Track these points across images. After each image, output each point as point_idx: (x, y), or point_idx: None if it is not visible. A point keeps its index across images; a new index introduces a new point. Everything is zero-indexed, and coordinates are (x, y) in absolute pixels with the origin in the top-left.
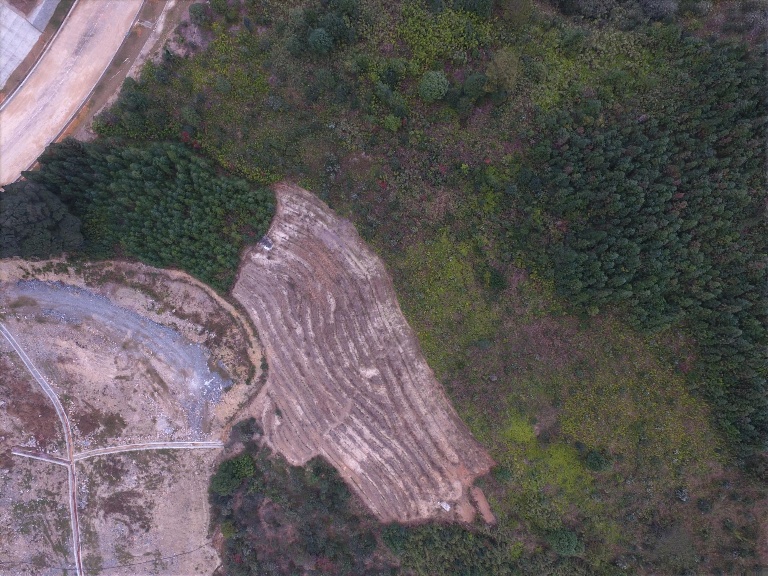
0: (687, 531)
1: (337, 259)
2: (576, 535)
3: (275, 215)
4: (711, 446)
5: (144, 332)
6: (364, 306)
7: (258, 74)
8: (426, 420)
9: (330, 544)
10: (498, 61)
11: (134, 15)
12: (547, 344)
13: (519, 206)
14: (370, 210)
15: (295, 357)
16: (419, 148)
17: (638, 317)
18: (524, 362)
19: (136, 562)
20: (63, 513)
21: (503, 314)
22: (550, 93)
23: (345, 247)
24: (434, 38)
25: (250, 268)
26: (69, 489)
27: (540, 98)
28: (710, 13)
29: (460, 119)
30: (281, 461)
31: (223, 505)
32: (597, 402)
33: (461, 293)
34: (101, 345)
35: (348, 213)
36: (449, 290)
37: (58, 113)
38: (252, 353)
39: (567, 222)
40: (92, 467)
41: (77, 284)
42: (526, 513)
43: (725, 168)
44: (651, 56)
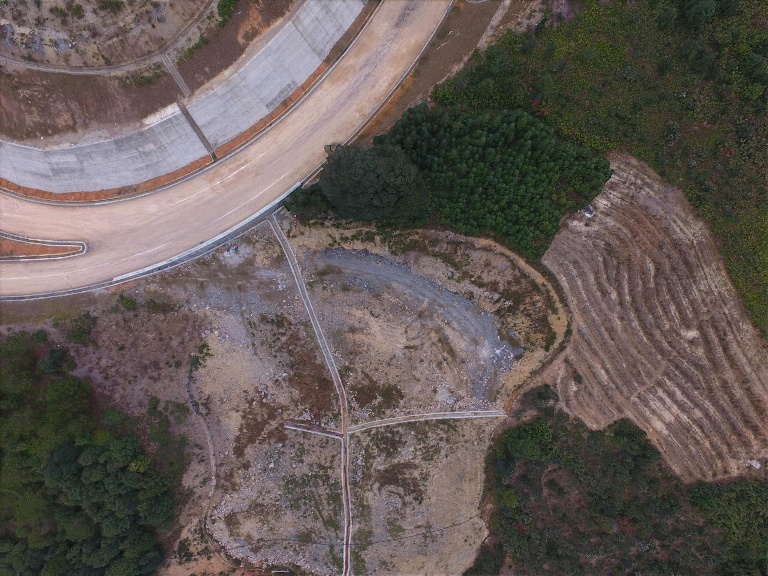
0: None
1: (661, 225)
2: None
3: None
4: None
5: (440, 301)
6: (689, 270)
7: None
8: (751, 378)
9: (631, 506)
10: None
11: None
12: None
13: None
14: (707, 176)
15: (606, 322)
16: None
17: None
18: None
19: (407, 535)
20: (335, 487)
21: None
22: None
23: (672, 213)
24: None
25: (566, 235)
26: (341, 462)
27: None
28: None
29: None
30: (582, 425)
31: (506, 473)
32: None
33: None
34: (396, 314)
35: (678, 180)
36: None
37: (380, 83)
38: (555, 319)
39: None
40: (369, 439)
41: (380, 253)
42: None
43: None
44: None
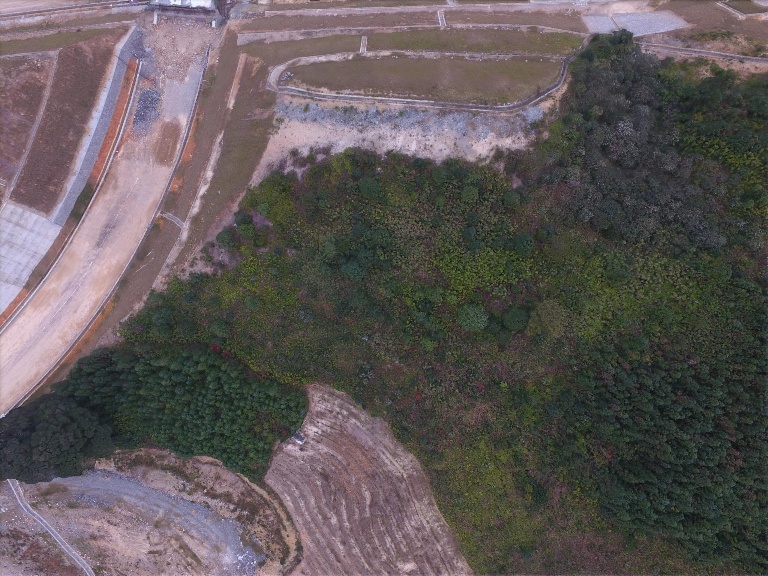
0: None
1: (371, 455)
2: None
3: (307, 412)
4: None
5: (176, 510)
6: (400, 503)
7: (288, 291)
8: None
9: None
10: (542, 315)
11: (155, 206)
12: (591, 558)
13: (561, 425)
14: (405, 416)
15: (330, 544)
16: (456, 365)
17: (688, 550)
18: (568, 573)
19: None
20: None
21: (545, 524)
22: (593, 323)
23: (380, 445)
24: (472, 274)
25: (282, 458)
26: None
27: (583, 330)
28: (761, 250)
29: (499, 343)
30: None
31: None
32: None
33: (501, 501)
34: (133, 523)
35: (382, 414)
36: (488, 495)
37: (82, 308)
38: (286, 535)
39: (612, 448)
40: None
41: (107, 468)
42: None
43: None
44: (698, 290)
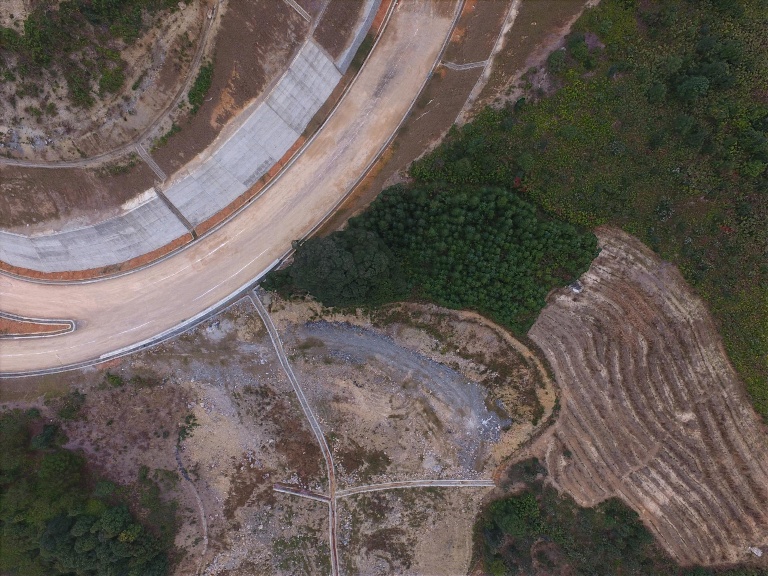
0: None
1: (655, 302)
2: None
3: None
4: None
5: (424, 372)
6: (684, 350)
7: (606, 120)
8: (751, 466)
9: None
10: None
11: (435, 56)
12: None
13: None
14: (704, 254)
15: (596, 399)
16: None
17: None
18: None
19: None
20: (323, 549)
21: None
22: None
23: (666, 290)
24: None
25: (553, 310)
26: (329, 525)
27: None
28: None
29: None
30: (571, 502)
31: (494, 544)
32: None
33: None
34: (379, 384)
35: (673, 256)
36: None
37: (359, 156)
38: (543, 394)
39: None
40: (356, 504)
41: (363, 325)
42: None
43: None
44: None
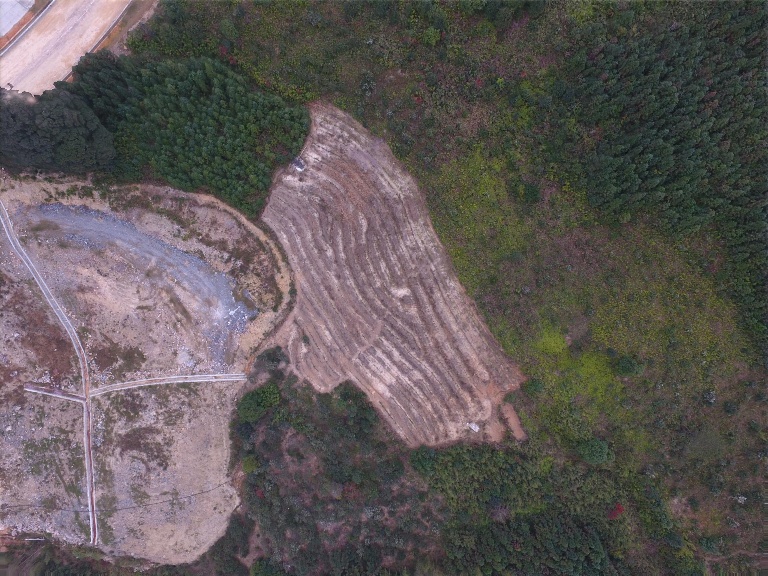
0: (714, 435)
1: (370, 179)
2: (607, 444)
3: (308, 135)
4: (738, 347)
5: (169, 260)
6: (396, 225)
7: None
8: (458, 337)
9: (357, 471)
10: None
11: None
12: (579, 255)
13: (553, 119)
14: (405, 127)
15: (325, 280)
16: (456, 63)
17: (669, 220)
18: (556, 274)
19: (152, 502)
20: (77, 451)
21: (535, 227)
22: (584, 7)
23: (378, 166)
24: None
25: (281, 190)
26: (84, 427)
27: (575, 10)
28: None
29: (497, 32)
30: (308, 388)
31: (245, 438)
32: (628, 308)
33: (494, 208)
34: (124, 273)
35: (382, 132)
36: (482, 206)
37: (88, 33)
38: (280, 279)
39: (600, 132)
40: (109, 402)
41: (101, 209)
42: (557, 426)
43: (754, 68)
44: None
